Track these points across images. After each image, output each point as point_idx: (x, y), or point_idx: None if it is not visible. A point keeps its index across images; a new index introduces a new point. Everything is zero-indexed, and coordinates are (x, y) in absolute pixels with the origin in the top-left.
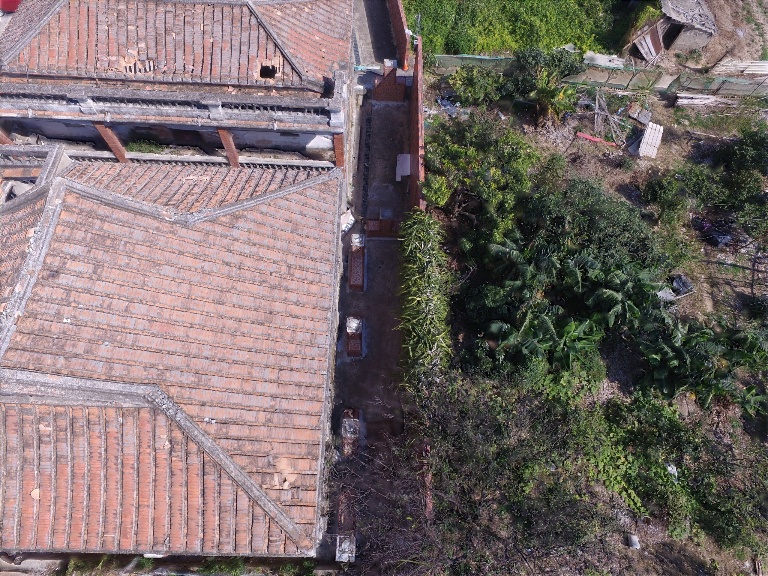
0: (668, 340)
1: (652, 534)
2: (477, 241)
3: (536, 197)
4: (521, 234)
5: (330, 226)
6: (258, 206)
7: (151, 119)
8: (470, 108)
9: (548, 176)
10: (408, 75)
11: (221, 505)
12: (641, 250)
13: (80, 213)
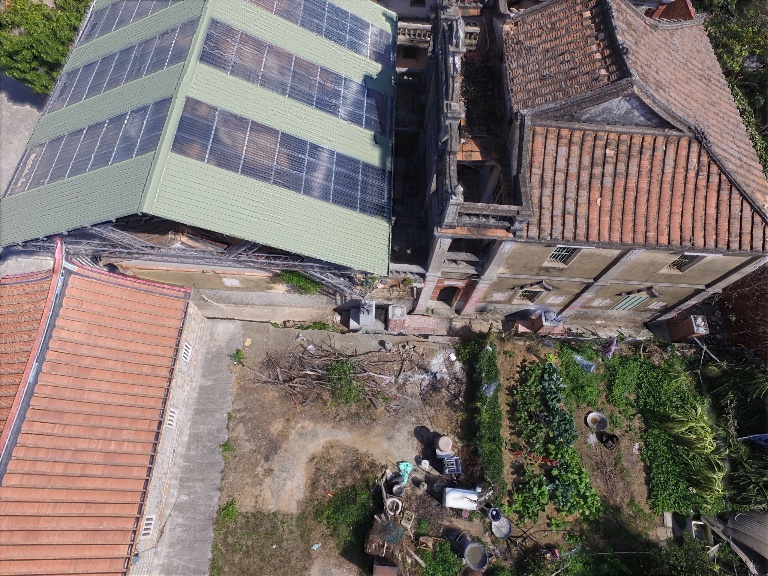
0: None
1: None
2: (767, 100)
3: None
4: None
5: (713, 55)
6: (676, 30)
7: None
8: (704, 14)
9: None
10: None
11: (731, 213)
12: None
13: None
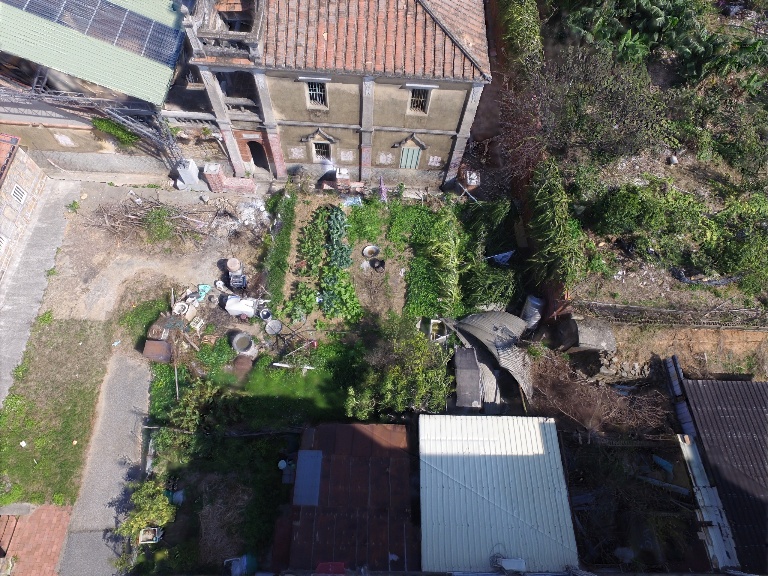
0: (697, 38)
1: (686, 160)
2: None
3: None
4: None
5: None
6: None
7: None
8: None
9: None
10: None
11: (436, 46)
12: None
13: None
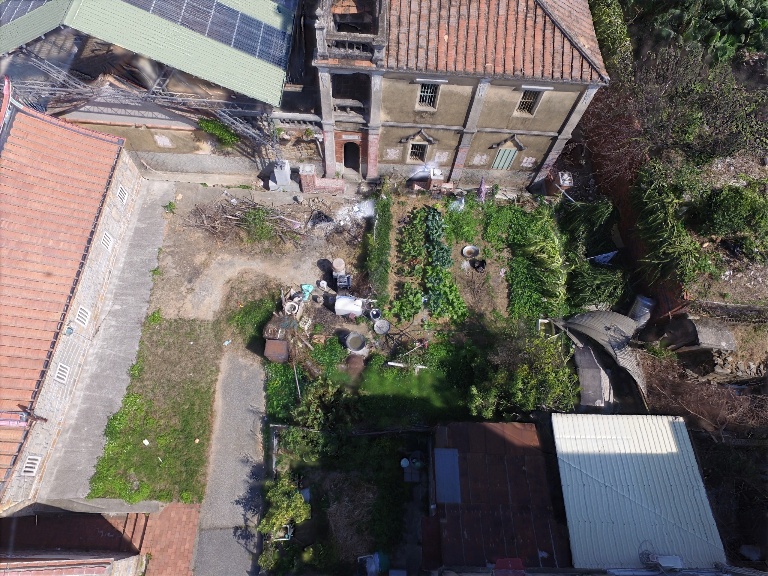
0: None
1: None
2: None
3: None
4: None
5: None
6: None
7: None
8: None
9: None
10: None
11: (555, 49)
12: None
13: None
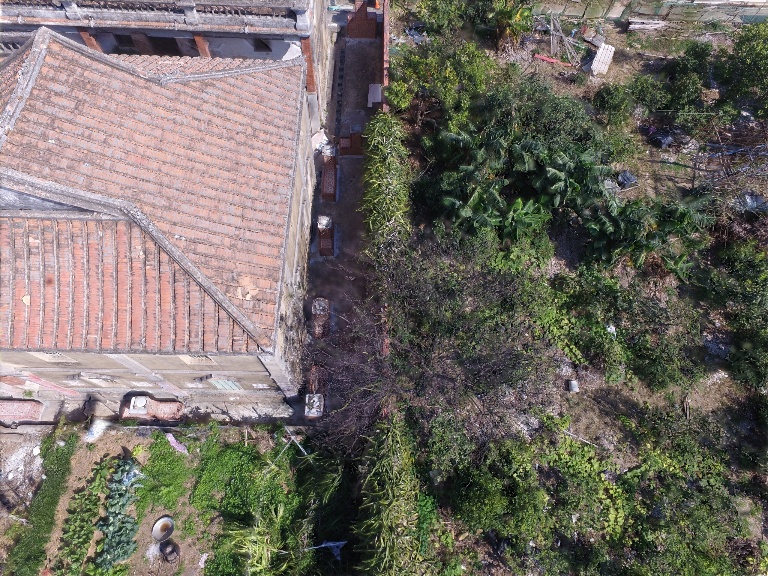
0: (605, 211)
1: (591, 382)
2: (436, 140)
3: (488, 95)
4: (475, 128)
5: (293, 103)
6: (226, 78)
7: (131, 24)
8: (436, 37)
9: (502, 82)
10: (379, 13)
11: (190, 309)
12: (584, 139)
13: (63, 60)
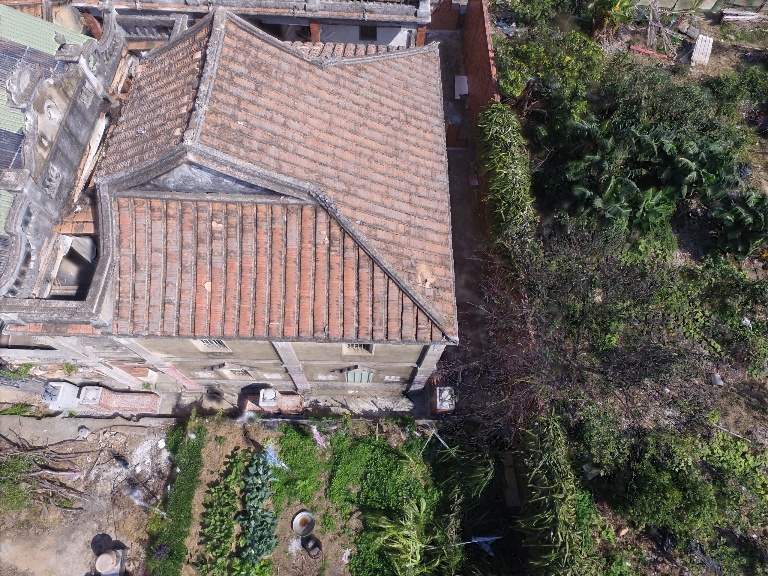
0: (741, 202)
1: (733, 375)
2: (551, 130)
3: (608, 84)
4: None
5: (434, 89)
6: (374, 63)
7: (250, 10)
8: (525, 28)
9: (614, 71)
10: (461, 4)
11: (374, 296)
12: (709, 129)
13: (238, 41)
